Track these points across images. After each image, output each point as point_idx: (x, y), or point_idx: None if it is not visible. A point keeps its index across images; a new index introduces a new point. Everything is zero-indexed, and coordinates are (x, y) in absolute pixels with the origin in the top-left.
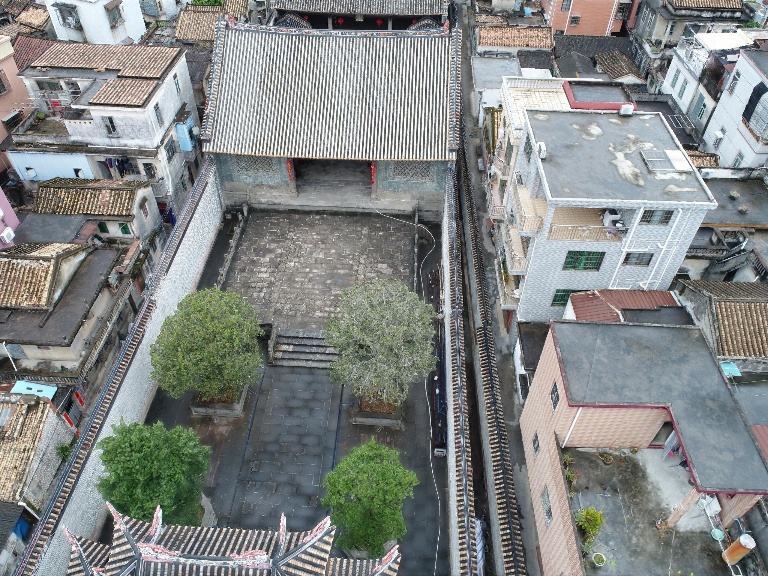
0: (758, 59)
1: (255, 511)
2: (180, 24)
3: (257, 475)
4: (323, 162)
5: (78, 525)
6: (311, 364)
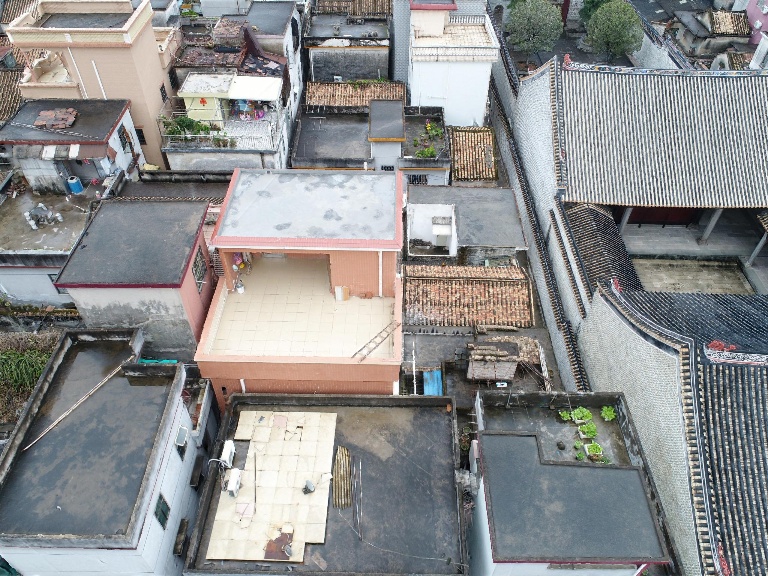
0: (279, 28)
1: None
2: None
3: None
4: None
5: None
6: None
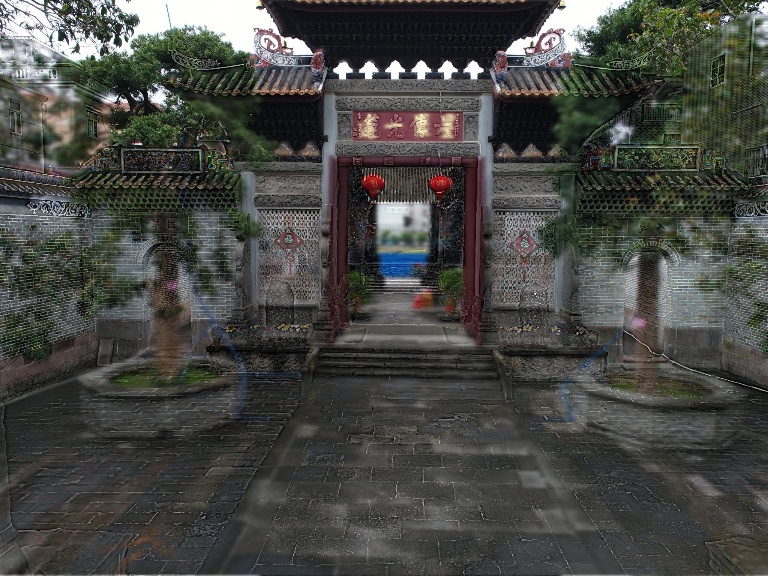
0: None
1: (372, 320)
2: None
3: (367, 313)
4: (384, 260)
5: (155, 267)
6: (408, 292)
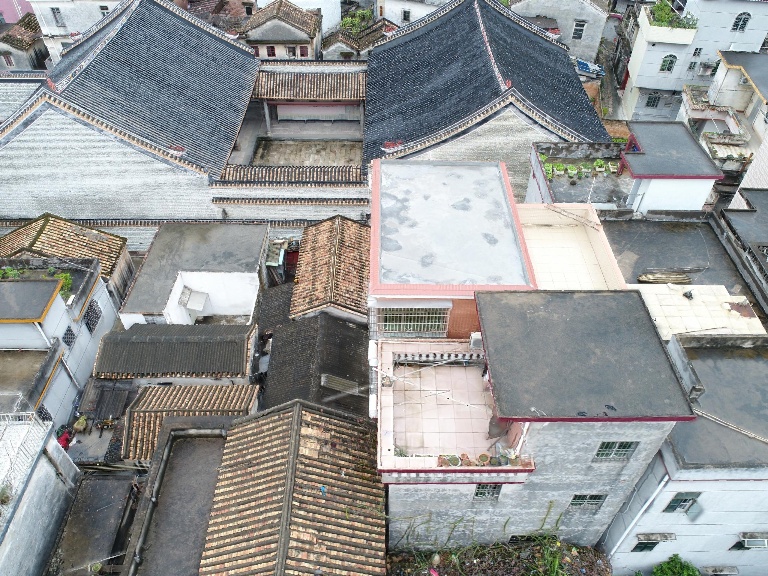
0: None
1: None
2: (265, 8)
3: None
4: None
5: None
6: None
